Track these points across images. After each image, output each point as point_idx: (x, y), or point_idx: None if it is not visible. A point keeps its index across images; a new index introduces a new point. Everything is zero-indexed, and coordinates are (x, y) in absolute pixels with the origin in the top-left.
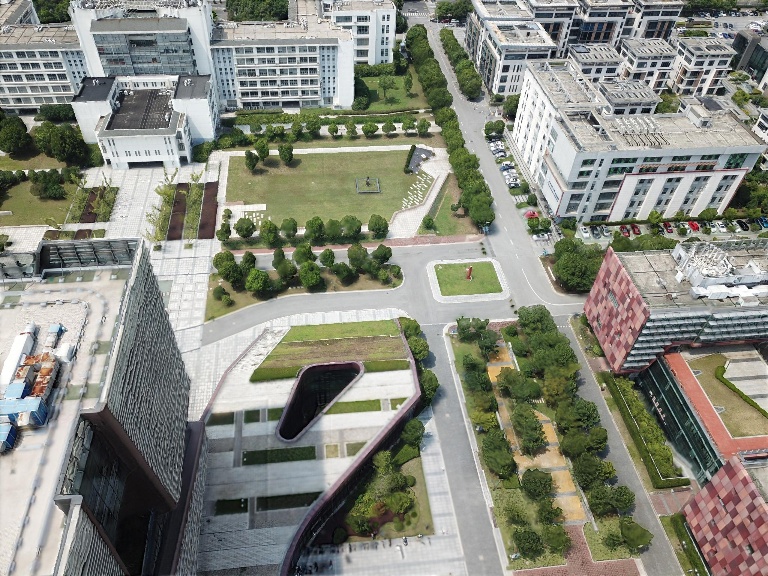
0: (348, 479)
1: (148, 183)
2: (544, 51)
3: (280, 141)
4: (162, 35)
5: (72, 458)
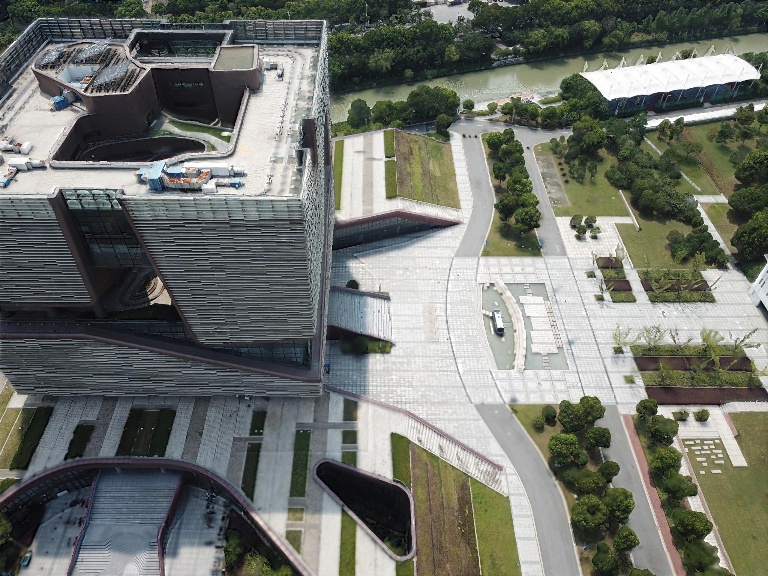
0: None
1: (736, 328)
2: None
3: None
4: None
5: (91, 194)
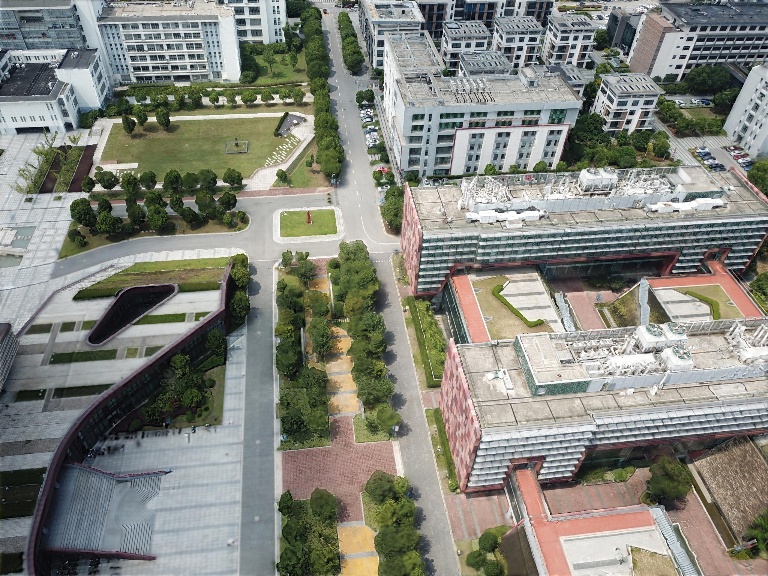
0: (147, 378)
1: (32, 146)
2: (414, 26)
3: None
4: (48, 11)
5: None
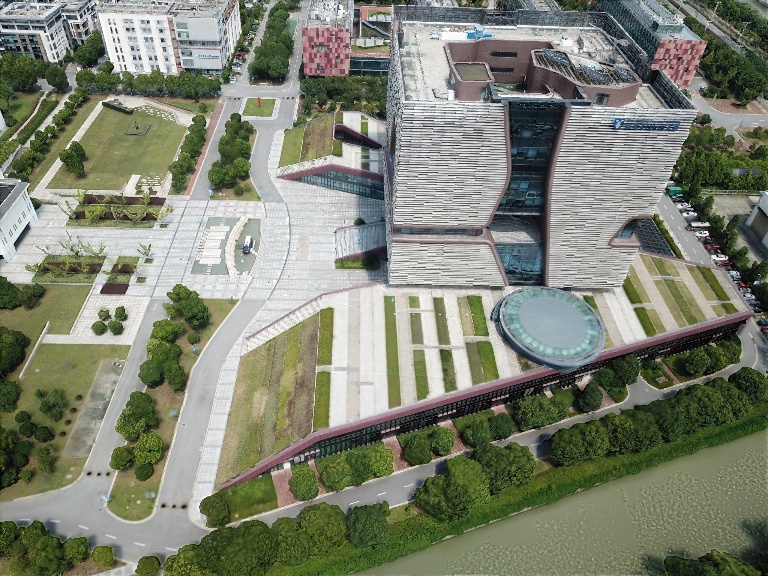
0: None
1: (53, 237)
2: (59, 12)
3: (37, 164)
4: None
5: None
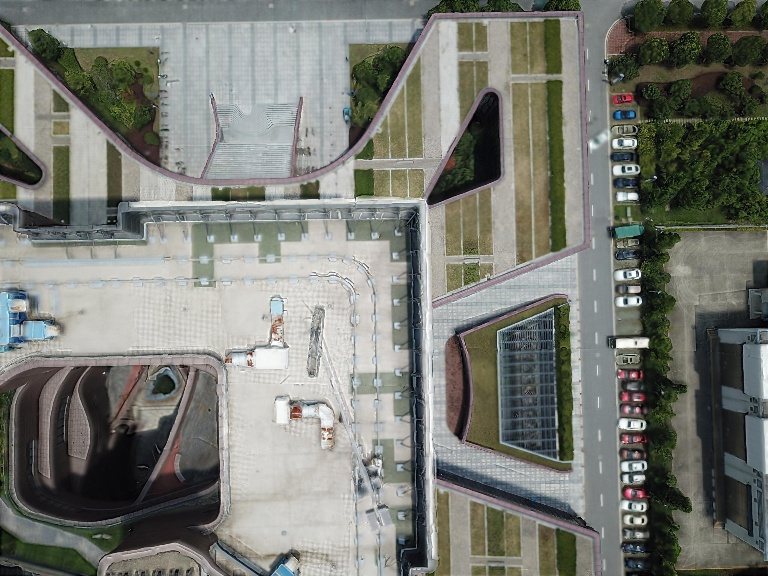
0: None
1: None
2: None
3: None
4: None
5: None
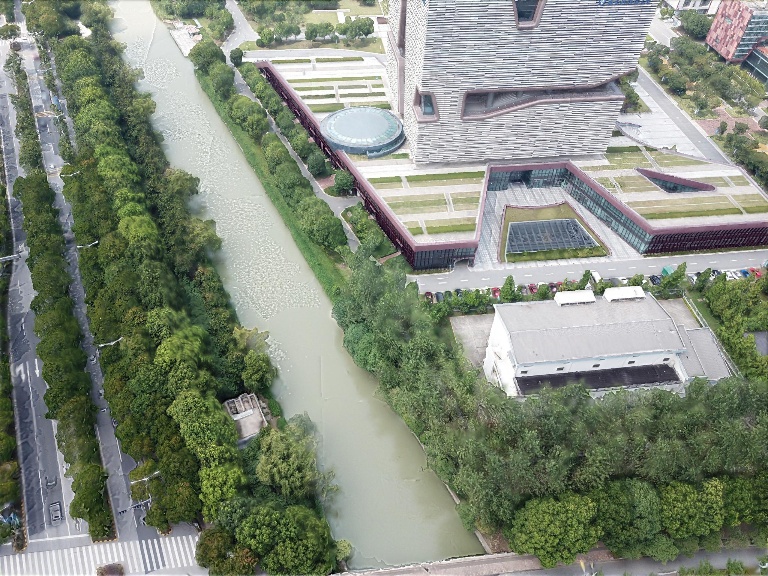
0: None
1: None
2: None
3: None
4: None
5: None
